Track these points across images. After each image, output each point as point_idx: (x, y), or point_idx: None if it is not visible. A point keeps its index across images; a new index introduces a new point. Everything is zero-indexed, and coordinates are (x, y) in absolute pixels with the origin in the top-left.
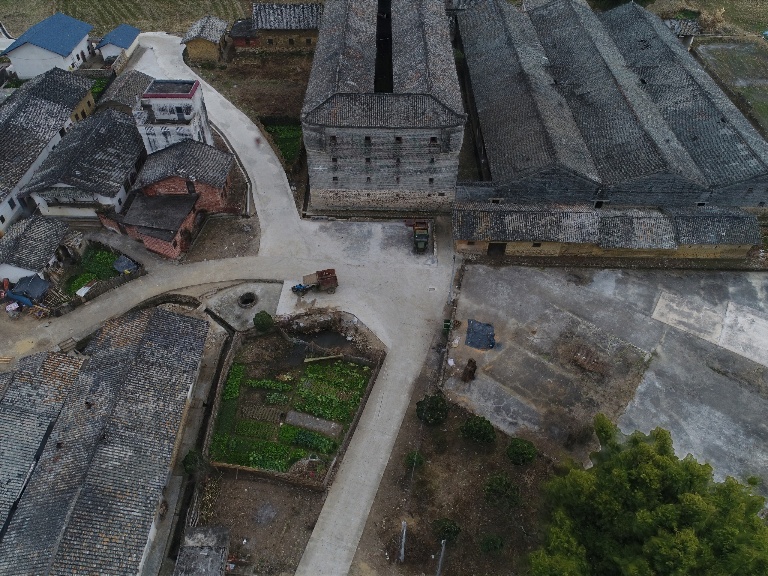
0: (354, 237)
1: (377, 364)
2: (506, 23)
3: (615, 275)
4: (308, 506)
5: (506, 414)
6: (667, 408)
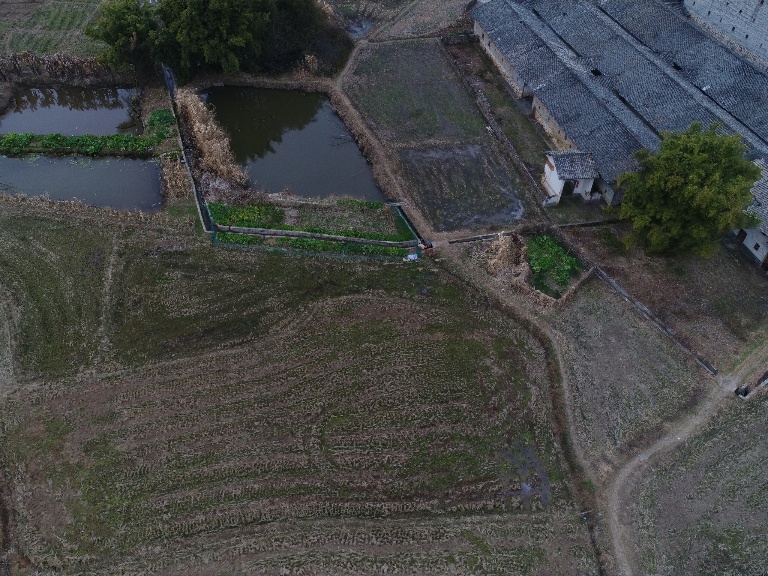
0: None
1: None
2: None
3: None
4: None
5: None
6: None
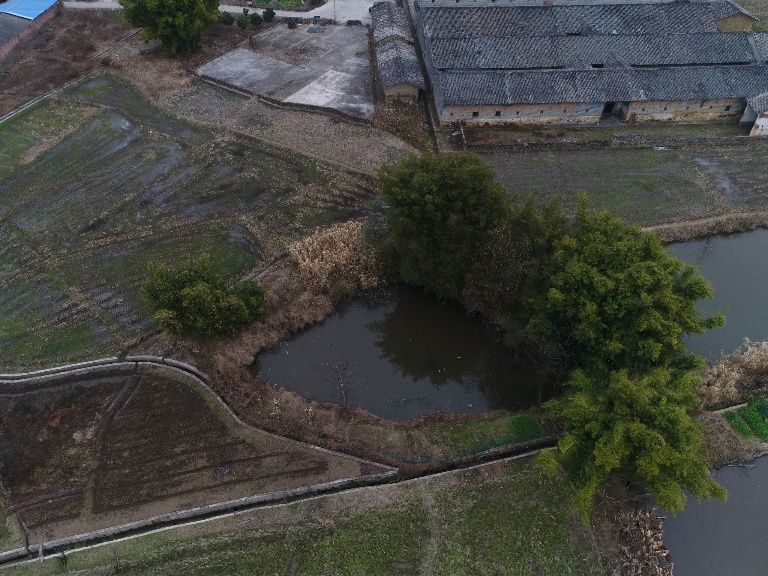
0: (381, 1)
1: (295, 6)
2: (645, 5)
3: (365, 64)
4: (236, 5)
5: (270, 34)
6: (269, 66)
